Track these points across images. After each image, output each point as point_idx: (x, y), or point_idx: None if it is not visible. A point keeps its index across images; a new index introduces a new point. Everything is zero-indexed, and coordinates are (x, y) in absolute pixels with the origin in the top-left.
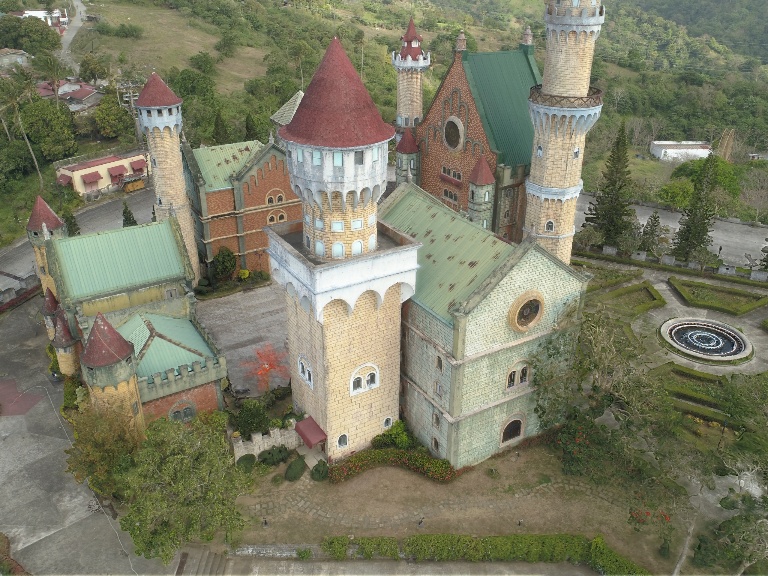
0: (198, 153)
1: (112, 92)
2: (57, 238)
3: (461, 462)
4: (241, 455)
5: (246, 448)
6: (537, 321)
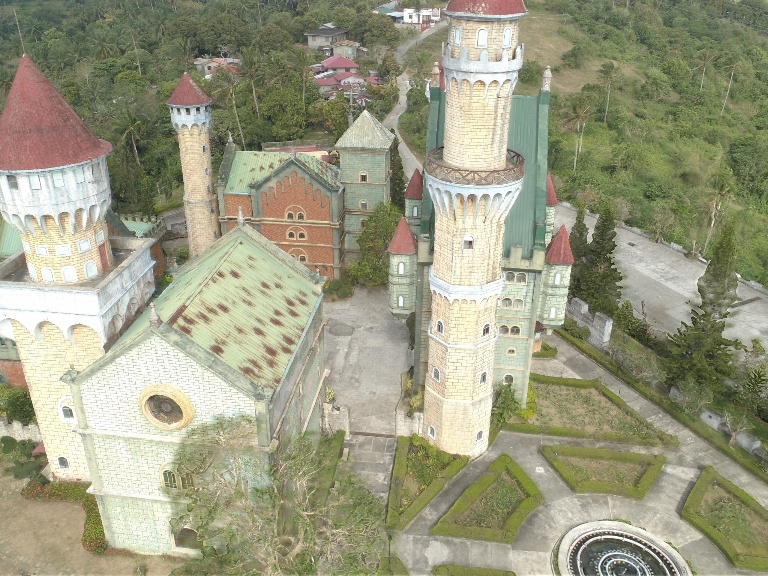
0: (241, 155)
1: None
2: None
3: (121, 542)
4: (4, 434)
5: (8, 430)
6: (179, 423)
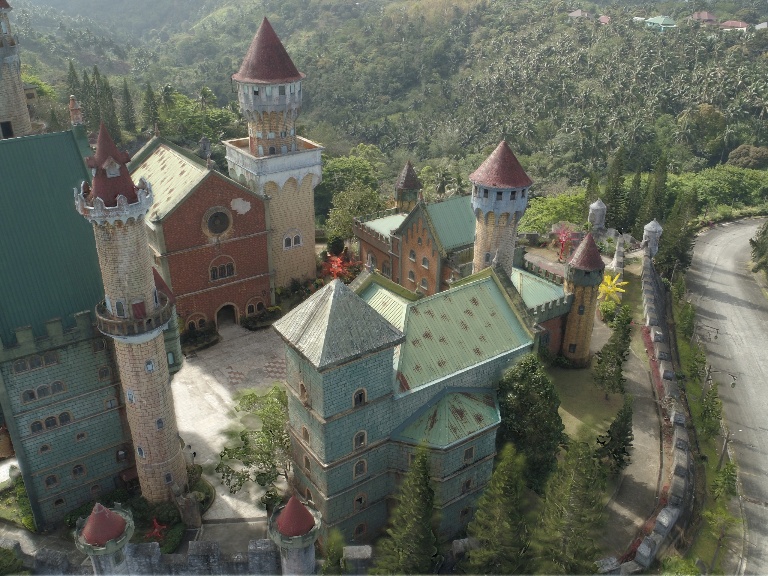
0: None
1: None
2: None
3: None
4: None
5: None
6: None
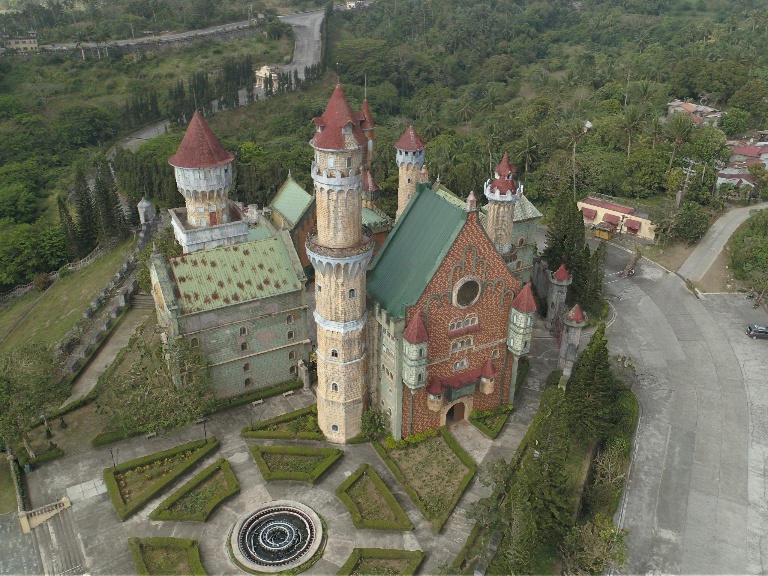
0: None
1: None
2: None
3: None
4: None
5: None
6: None
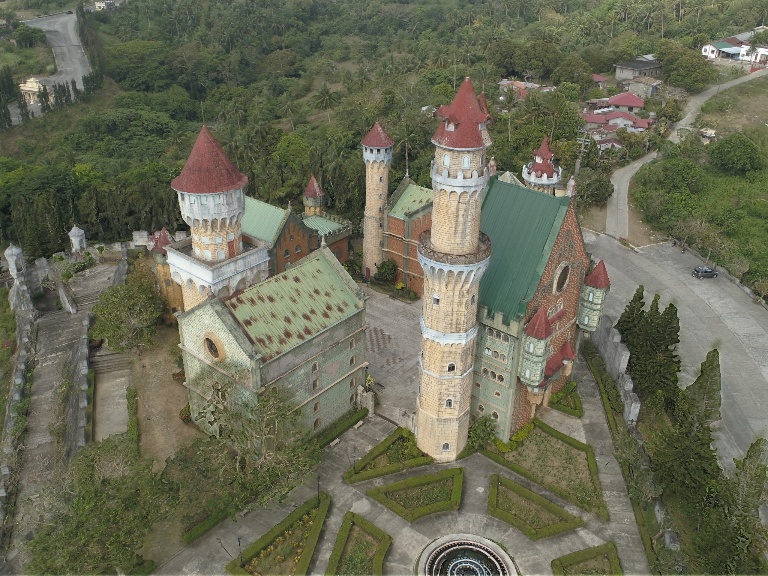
0: (412, 188)
1: (617, 134)
2: (310, 203)
3: None
4: None
5: None
6: None
